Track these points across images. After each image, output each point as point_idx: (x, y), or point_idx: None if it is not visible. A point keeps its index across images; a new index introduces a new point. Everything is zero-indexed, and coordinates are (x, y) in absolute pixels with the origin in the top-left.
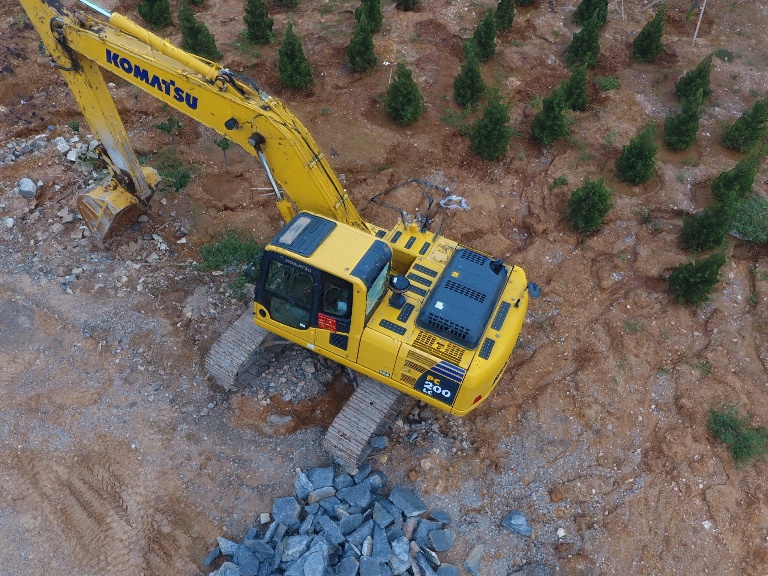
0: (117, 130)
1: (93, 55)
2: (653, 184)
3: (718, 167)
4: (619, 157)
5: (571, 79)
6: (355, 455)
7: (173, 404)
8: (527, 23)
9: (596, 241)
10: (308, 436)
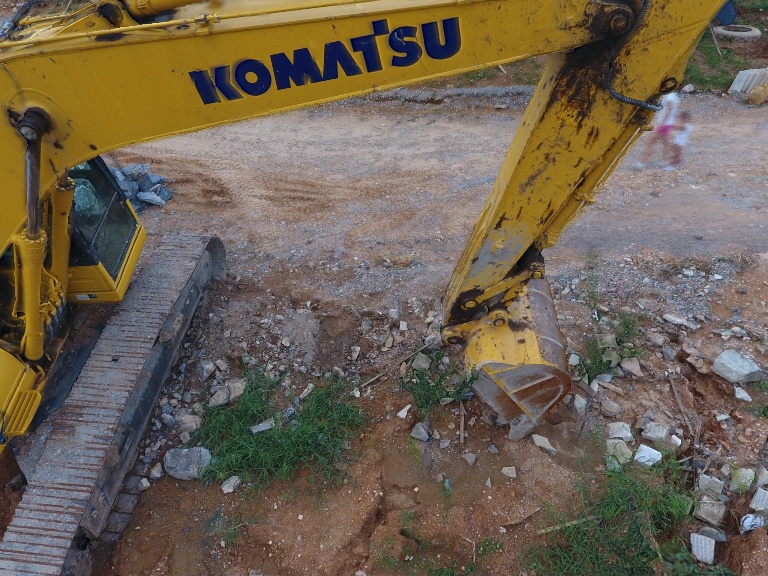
0: None
1: None
2: None
3: None
4: None
5: None
6: None
7: None
8: None
9: None
10: None
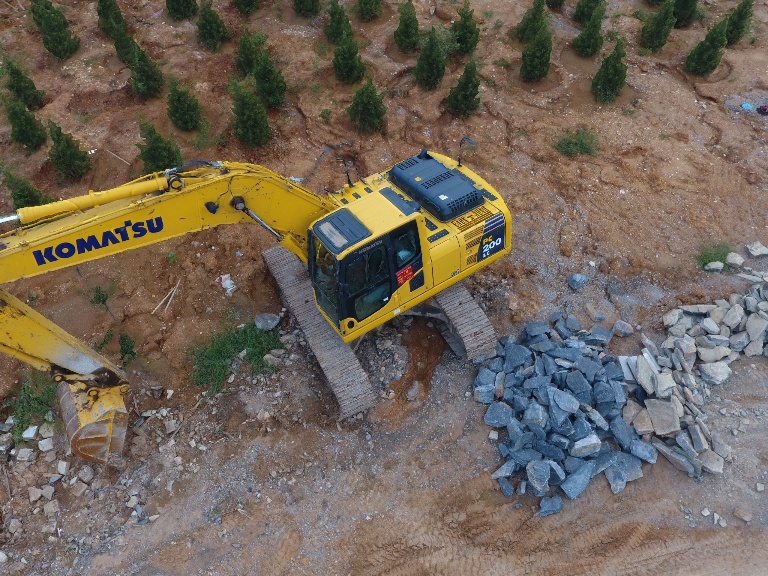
0: (67, 337)
1: (17, 274)
2: (368, 71)
3: (382, 34)
4: (337, 70)
5: (242, 50)
6: (493, 336)
7: (347, 469)
8: (145, 45)
9: (391, 126)
10: (442, 375)
